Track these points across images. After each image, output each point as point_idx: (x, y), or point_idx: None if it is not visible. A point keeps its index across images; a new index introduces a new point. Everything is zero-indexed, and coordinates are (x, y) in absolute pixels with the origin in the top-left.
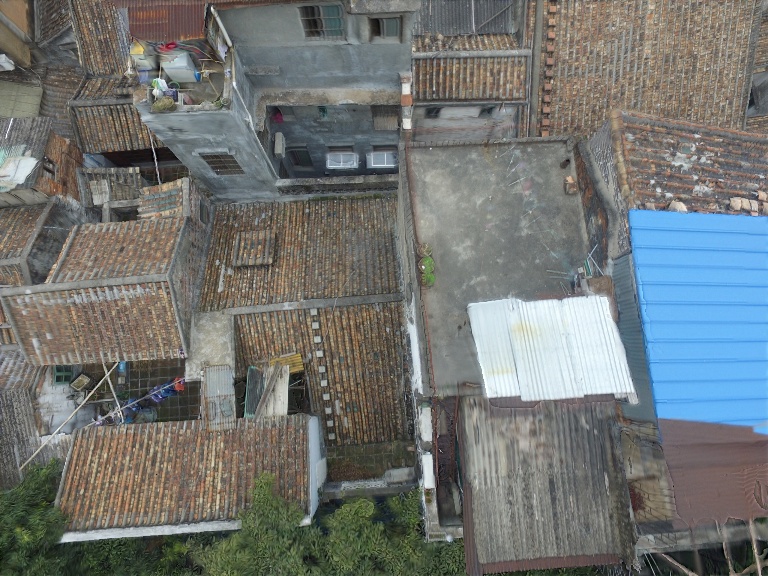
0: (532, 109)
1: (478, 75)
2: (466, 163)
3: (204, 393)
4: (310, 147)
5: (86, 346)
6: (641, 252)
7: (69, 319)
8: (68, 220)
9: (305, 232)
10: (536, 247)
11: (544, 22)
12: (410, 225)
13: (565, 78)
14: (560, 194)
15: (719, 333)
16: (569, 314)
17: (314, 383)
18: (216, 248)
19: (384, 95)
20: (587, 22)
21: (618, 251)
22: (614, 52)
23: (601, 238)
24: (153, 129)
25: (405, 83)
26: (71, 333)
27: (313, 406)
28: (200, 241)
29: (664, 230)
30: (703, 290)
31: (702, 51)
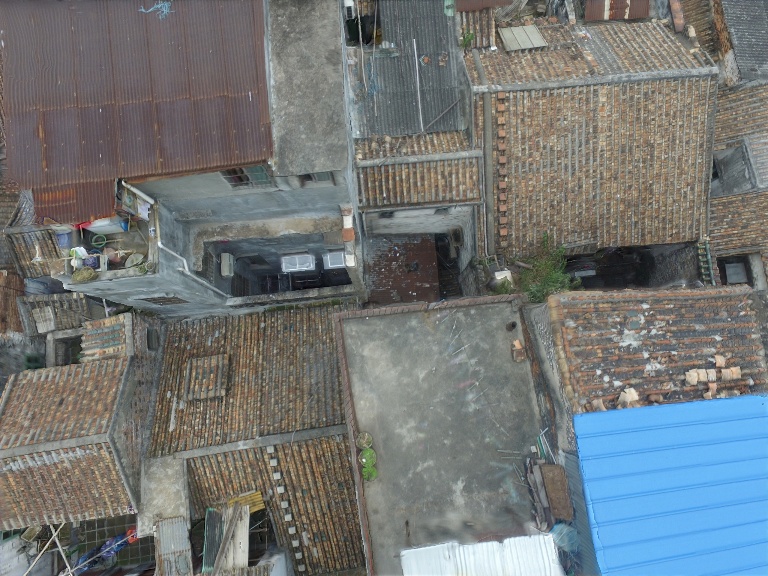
0: (488, 208)
1: (429, 178)
2: (406, 332)
3: (158, 550)
4: (262, 254)
5: (28, 510)
6: (589, 464)
7: (7, 486)
8: (9, 357)
9: (260, 352)
10: (485, 424)
11: (493, 120)
12: (349, 408)
13: (519, 175)
14: (508, 361)
15: (680, 548)
16: (511, 562)
17: (278, 518)
18: (167, 376)
19: (327, 222)
20: (538, 118)
21: (568, 446)
22: (568, 146)
23: (551, 424)
24: (78, 291)
25: (346, 215)
26: (11, 499)
27: (279, 540)
28: (149, 373)
29: (613, 434)
30: (659, 498)
31: (658, 139)
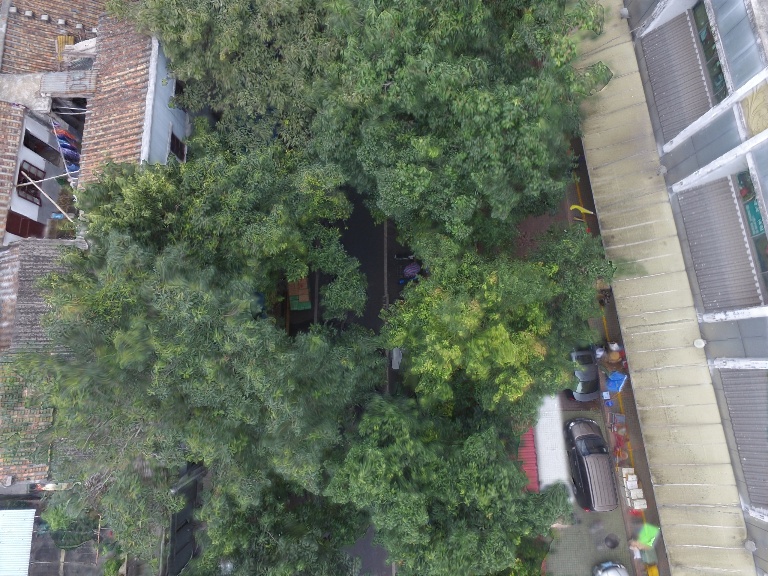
0: None
1: None
2: None
3: (62, 94)
4: None
5: None
6: None
7: None
8: None
9: None
10: None
11: None
12: None
13: None
14: None
15: None
16: None
17: None
18: None
19: None
20: None
21: None
22: None
23: None
24: None
25: None
26: None
27: None
28: None
29: None
30: None
31: None
